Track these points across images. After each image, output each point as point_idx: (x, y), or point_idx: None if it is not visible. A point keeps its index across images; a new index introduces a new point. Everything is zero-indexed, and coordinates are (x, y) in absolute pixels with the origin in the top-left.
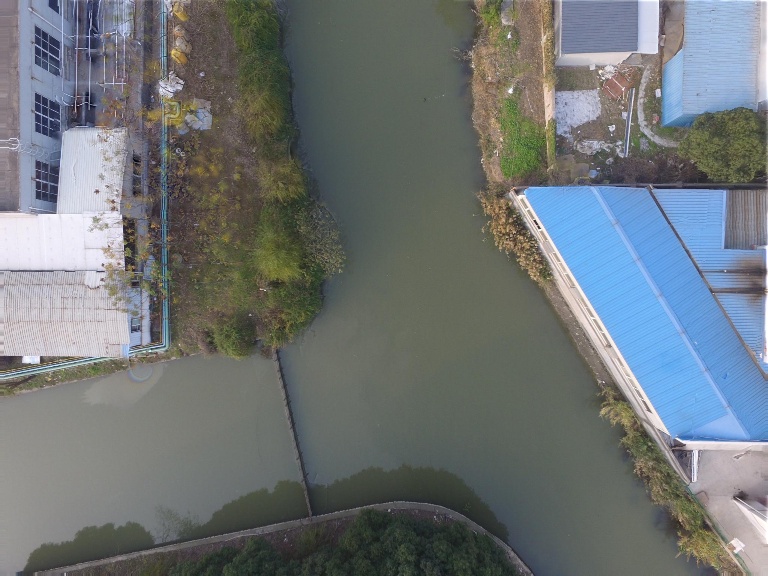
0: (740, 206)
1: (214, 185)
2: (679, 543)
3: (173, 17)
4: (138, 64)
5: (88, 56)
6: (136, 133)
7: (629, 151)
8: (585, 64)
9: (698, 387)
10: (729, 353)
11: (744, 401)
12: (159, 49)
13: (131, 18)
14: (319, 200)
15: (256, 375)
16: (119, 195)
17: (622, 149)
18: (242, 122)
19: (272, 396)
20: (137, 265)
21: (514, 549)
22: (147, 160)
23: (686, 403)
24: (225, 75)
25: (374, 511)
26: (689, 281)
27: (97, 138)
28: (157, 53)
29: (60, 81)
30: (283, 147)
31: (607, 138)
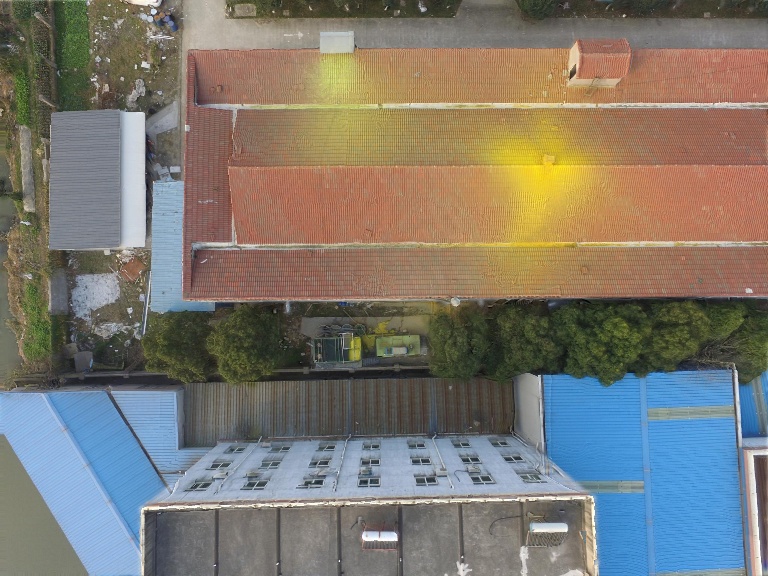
0: (212, 399)
1: None
2: None
3: None
4: None
5: None
6: None
7: (146, 333)
8: None
9: None
10: None
11: None
12: None
13: None
14: None
15: None
16: None
17: (139, 331)
18: None
19: None
20: None
21: None
22: None
23: None
24: None
25: None
26: (145, 483)
27: None
28: None
29: None
30: None
31: (125, 320)
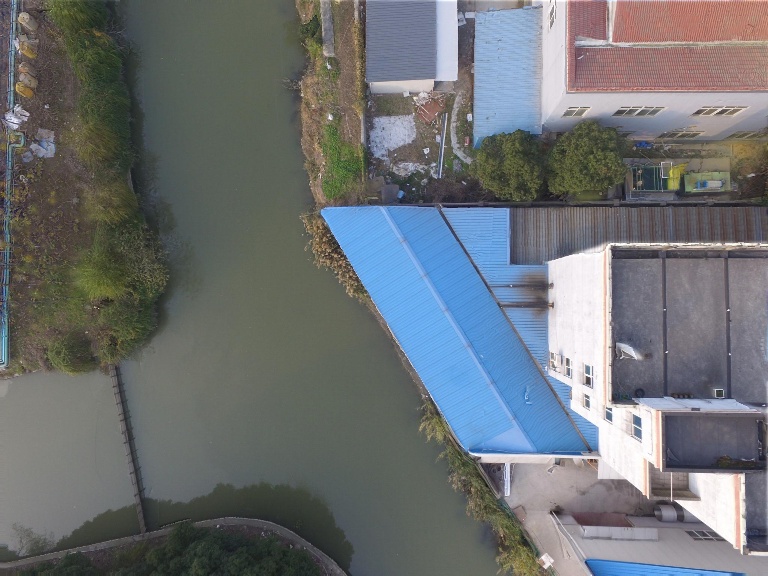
0: (532, 223)
1: (54, 209)
2: (500, 559)
3: (21, 55)
4: None
5: None
6: None
7: (443, 172)
8: (399, 91)
9: (486, 400)
10: None
11: (546, 414)
12: (6, 84)
13: None
14: (165, 222)
15: (91, 391)
16: None
17: (436, 170)
18: (82, 150)
19: (107, 411)
20: None
21: (340, 564)
22: None
23: (476, 416)
24: (69, 107)
25: (192, 525)
26: (477, 296)
27: None
28: (5, 88)
29: None
30: (112, 173)
31: (422, 160)
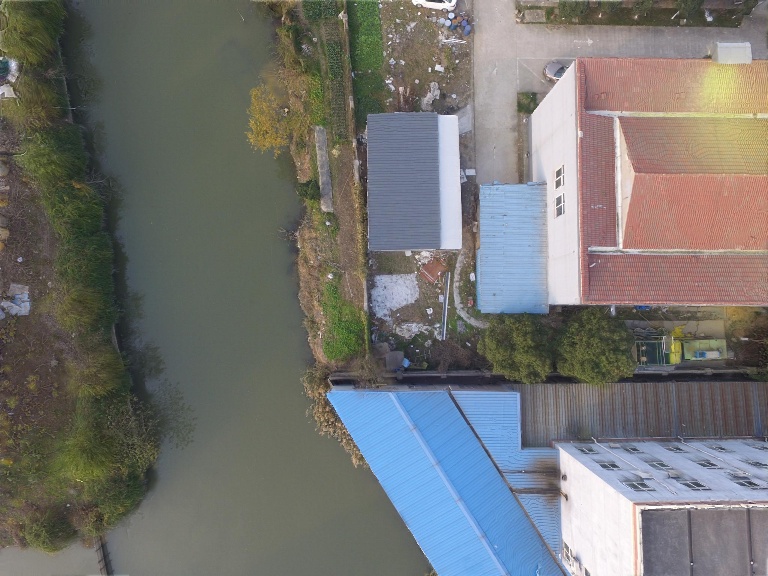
0: (540, 400)
1: (30, 373)
2: None
3: None
4: None
5: None
6: None
7: (447, 333)
8: (401, 250)
9: None
10: None
11: None
12: None
13: None
14: (151, 374)
15: (74, 568)
16: None
17: (440, 331)
18: (60, 308)
19: None
20: None
21: None
22: None
23: None
24: (44, 260)
25: None
26: (489, 482)
27: None
28: None
29: None
30: (96, 339)
31: (425, 321)
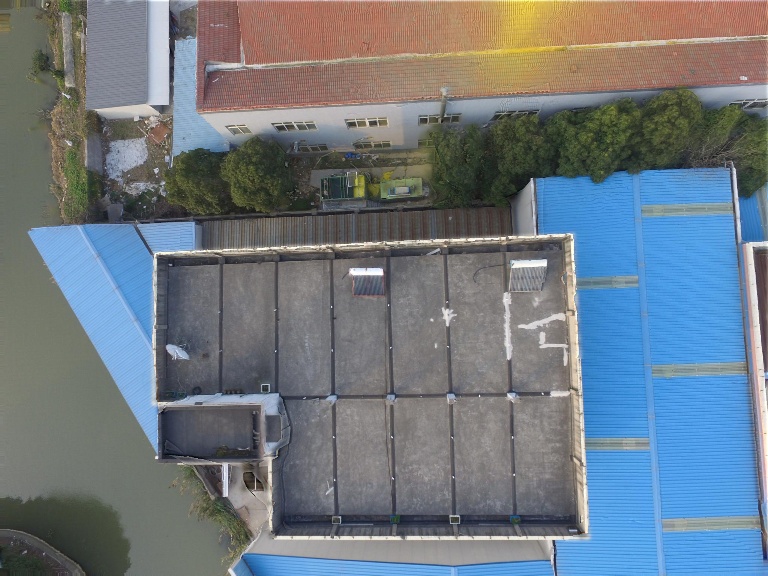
0: (227, 235)
1: None
2: (229, 558)
3: None
4: None
5: None
6: None
7: None
8: (131, 116)
9: None
10: None
11: None
12: None
13: None
14: None
15: None
16: None
17: (165, 189)
18: None
19: None
20: None
21: (85, 569)
22: None
23: None
24: None
25: None
26: None
27: None
28: None
29: None
30: None
31: (153, 180)
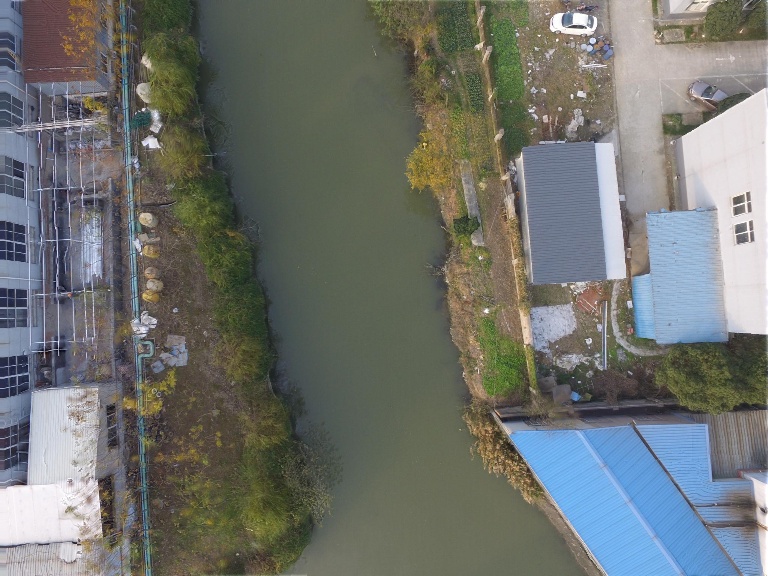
0: (722, 429)
1: (193, 424)
2: None
3: (142, 257)
4: (108, 313)
5: (56, 300)
6: (109, 383)
7: (608, 363)
8: None
9: None
10: (728, 574)
11: None
12: (129, 290)
13: (99, 259)
14: (302, 416)
15: None
16: (94, 463)
17: (601, 361)
18: (219, 357)
19: None
20: (115, 526)
21: None
22: (122, 407)
23: None
24: (199, 309)
25: None
26: (682, 516)
27: (68, 421)
28: (128, 294)
29: (27, 332)
30: (262, 387)
31: (585, 351)
